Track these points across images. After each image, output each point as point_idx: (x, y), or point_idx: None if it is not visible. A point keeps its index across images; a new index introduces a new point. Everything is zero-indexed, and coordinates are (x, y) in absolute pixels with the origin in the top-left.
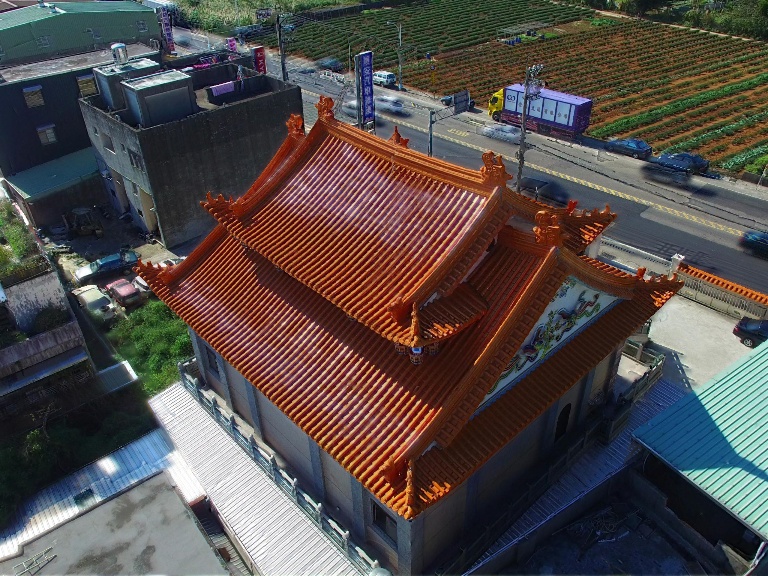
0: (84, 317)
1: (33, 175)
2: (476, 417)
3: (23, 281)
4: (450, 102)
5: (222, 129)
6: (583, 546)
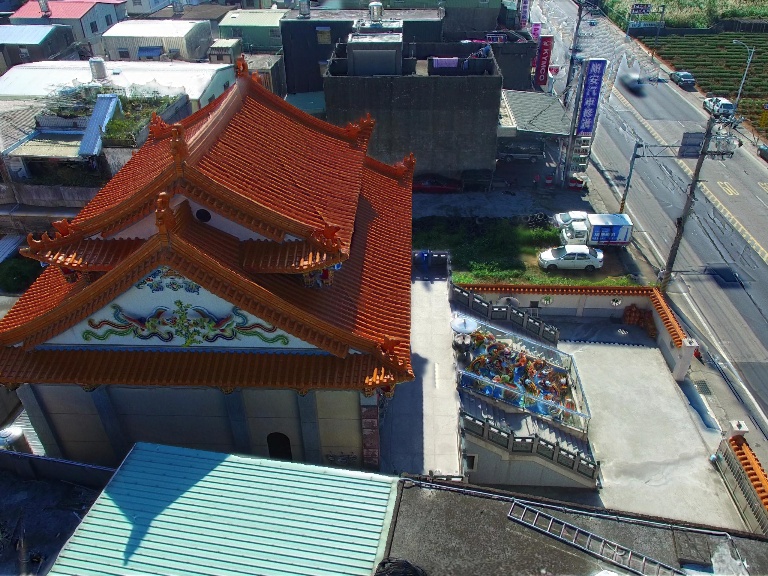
0: None
1: (304, 98)
2: (81, 351)
3: (116, 147)
4: (765, 153)
5: (405, 96)
6: (61, 504)
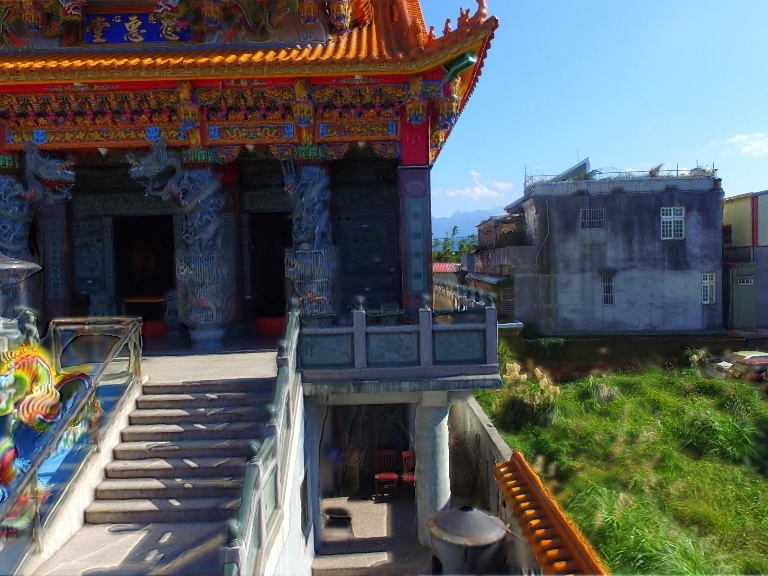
0: (669, 337)
1: None
2: None
3: None
4: None
5: None
6: None
